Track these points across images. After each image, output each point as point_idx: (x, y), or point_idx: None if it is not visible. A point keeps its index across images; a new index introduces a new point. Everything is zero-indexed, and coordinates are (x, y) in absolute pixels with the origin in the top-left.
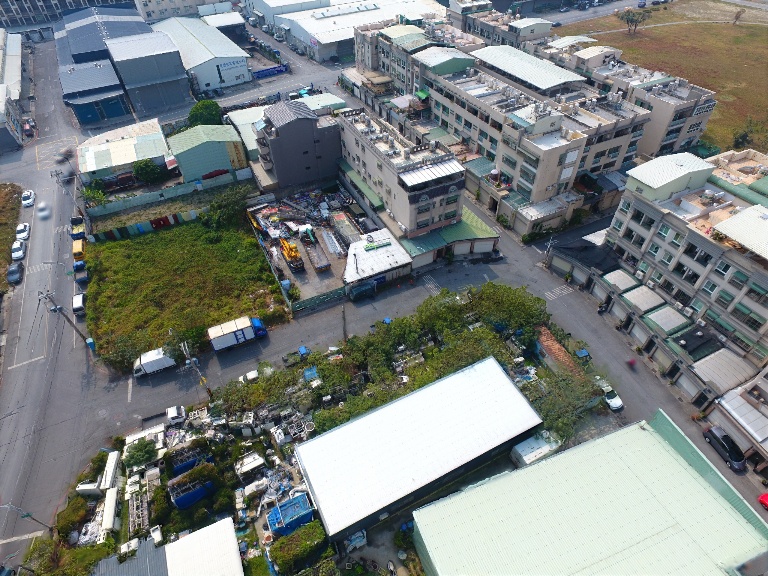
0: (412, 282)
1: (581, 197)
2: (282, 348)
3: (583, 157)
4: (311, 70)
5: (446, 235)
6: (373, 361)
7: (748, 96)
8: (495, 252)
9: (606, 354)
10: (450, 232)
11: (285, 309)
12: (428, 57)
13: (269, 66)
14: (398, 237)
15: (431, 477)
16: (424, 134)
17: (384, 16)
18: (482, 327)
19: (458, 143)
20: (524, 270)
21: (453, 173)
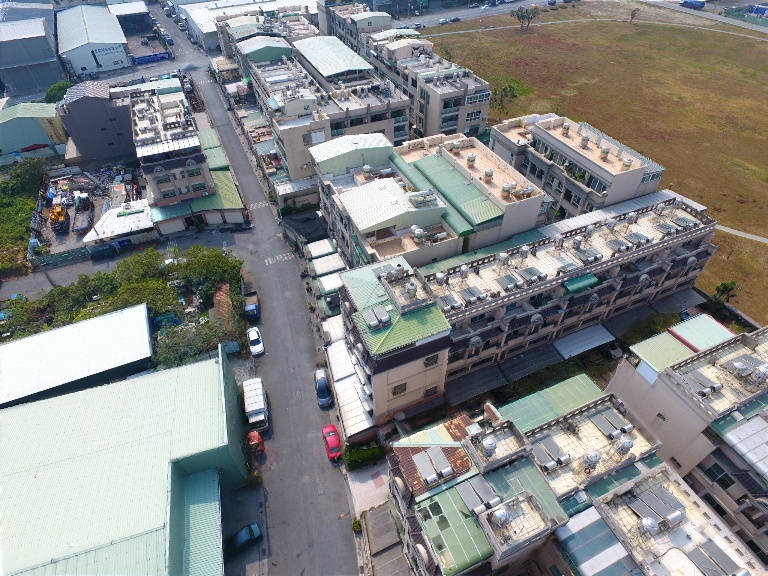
0: (156, 246)
1: None
2: (6, 296)
3: None
4: (193, 58)
5: (195, 205)
6: (58, 306)
7: (591, 91)
8: (247, 223)
9: (282, 311)
10: (200, 203)
11: (28, 264)
12: (248, 45)
13: (157, 53)
14: (148, 205)
15: (24, 394)
16: (241, 117)
17: None
18: (179, 283)
19: (266, 126)
20: (262, 239)
21: (187, 147)
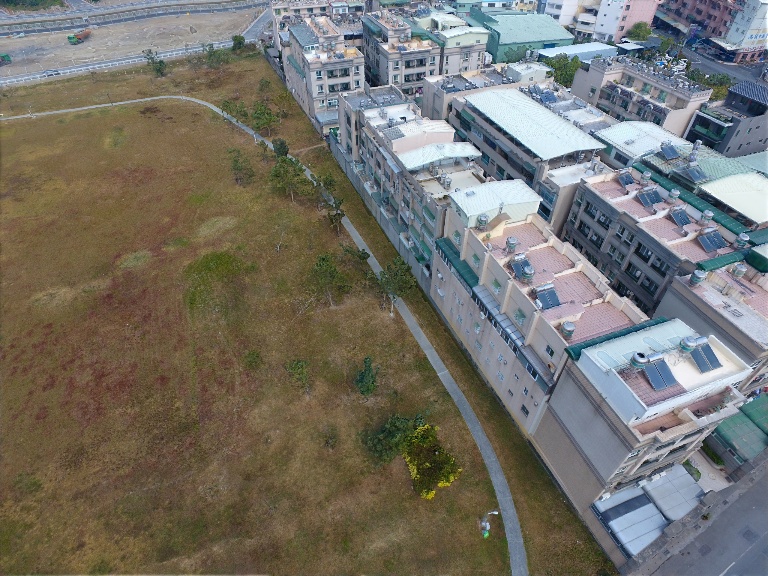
0: None
1: None
2: None
3: None
4: None
5: None
6: None
7: (96, 259)
8: None
9: None
10: None
11: None
12: (664, 132)
13: None
14: None
15: None
16: None
17: None
18: None
19: None
20: None
21: None
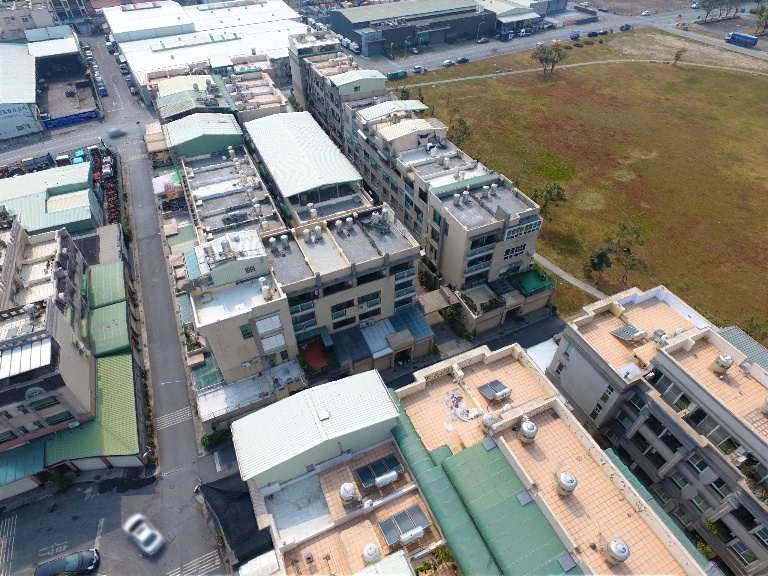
0: None
1: (299, 376)
2: None
3: (310, 313)
4: (129, 117)
5: (54, 448)
6: None
7: (652, 173)
8: (148, 467)
9: None
10: (64, 442)
11: None
12: (177, 130)
13: (83, 109)
14: None
15: None
16: (169, 235)
17: (240, 49)
18: None
19: None
20: (169, 511)
21: (23, 372)
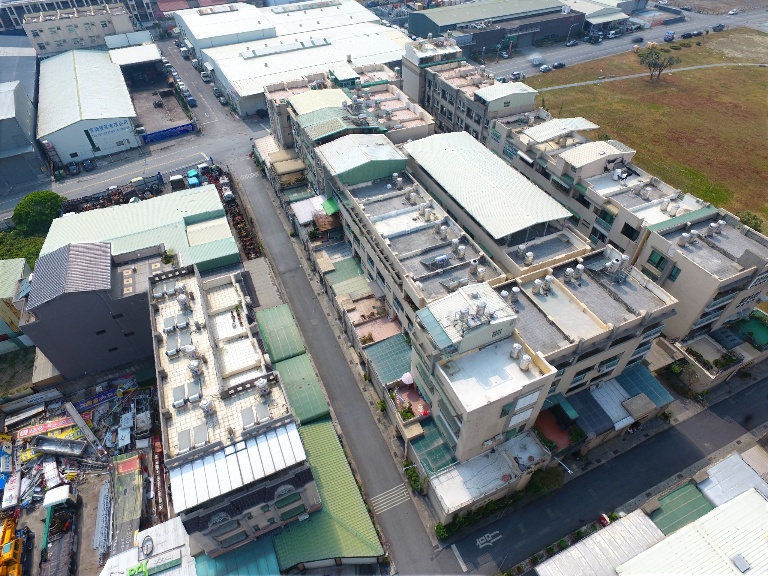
0: None
1: (546, 456)
2: None
3: None
4: (226, 130)
5: (285, 547)
6: None
7: None
8: (382, 564)
9: None
10: (294, 539)
11: None
12: (336, 155)
13: (175, 121)
14: (191, 556)
15: None
16: (325, 272)
17: (334, 55)
18: None
19: (371, 295)
20: None
21: (279, 470)
